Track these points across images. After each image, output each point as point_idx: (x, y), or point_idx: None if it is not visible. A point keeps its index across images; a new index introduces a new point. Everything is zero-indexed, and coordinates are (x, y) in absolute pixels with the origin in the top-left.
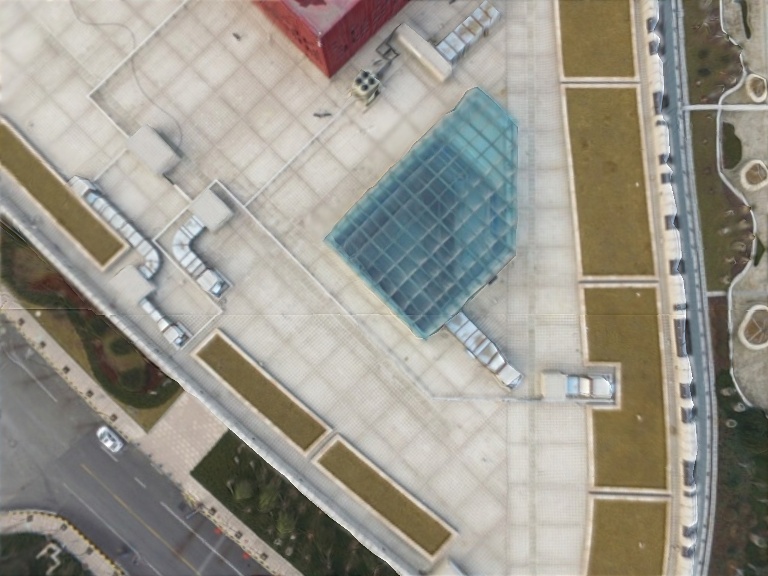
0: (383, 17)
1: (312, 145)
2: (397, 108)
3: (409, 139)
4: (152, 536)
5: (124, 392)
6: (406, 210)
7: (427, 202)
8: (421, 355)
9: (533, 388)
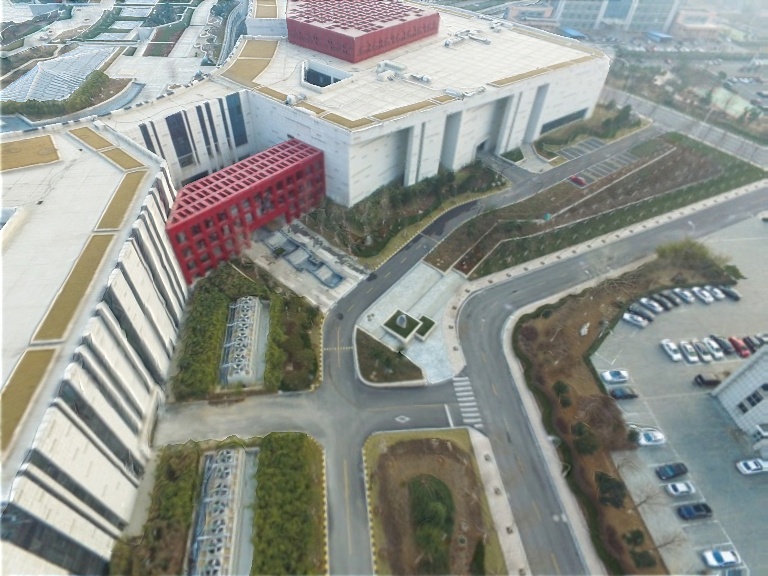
0: None
1: None
2: None
3: None
4: None
5: None
6: None
7: None
8: None
9: None
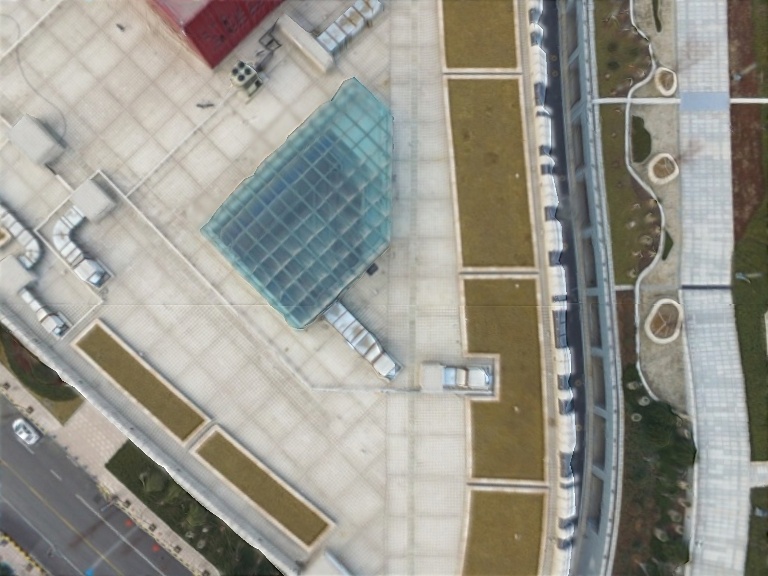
0: (263, 8)
1: (195, 136)
2: (280, 99)
3: (292, 130)
4: (67, 528)
5: (39, 384)
6: (281, 200)
7: (301, 192)
8: (301, 346)
9: (413, 379)
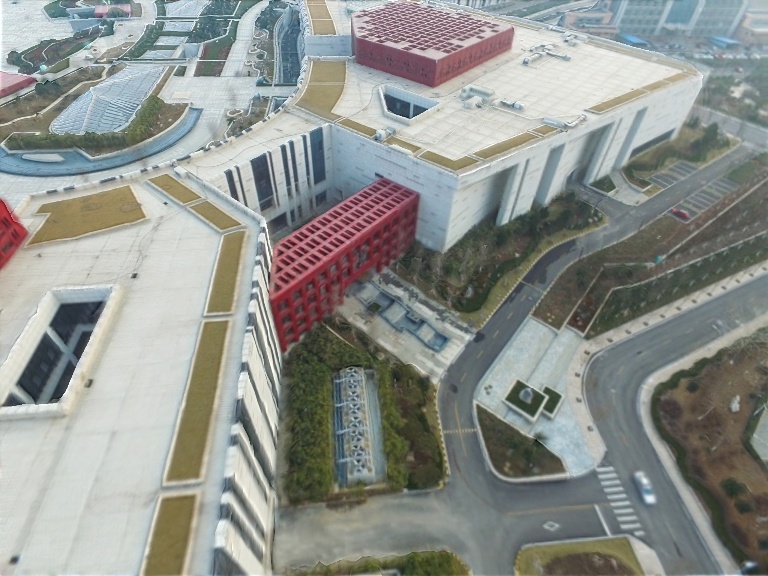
0: None
1: None
2: None
3: None
4: None
5: None
6: None
7: (369, 3)
8: None
9: None
